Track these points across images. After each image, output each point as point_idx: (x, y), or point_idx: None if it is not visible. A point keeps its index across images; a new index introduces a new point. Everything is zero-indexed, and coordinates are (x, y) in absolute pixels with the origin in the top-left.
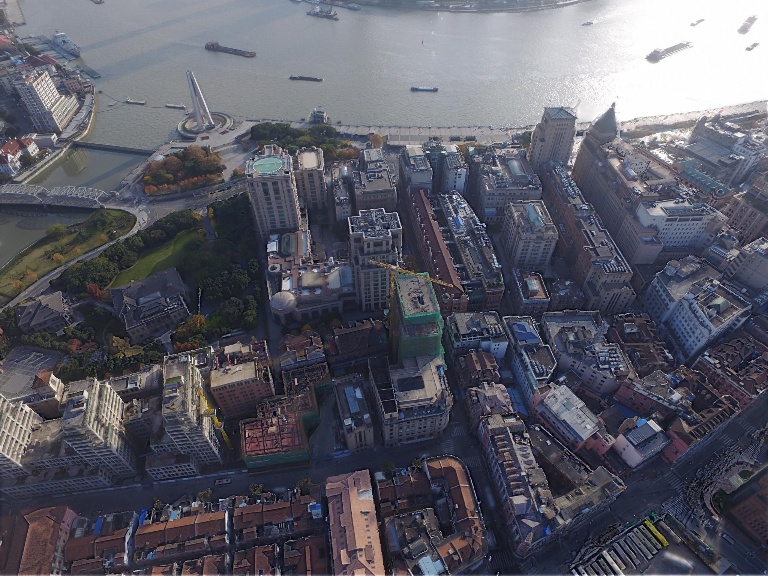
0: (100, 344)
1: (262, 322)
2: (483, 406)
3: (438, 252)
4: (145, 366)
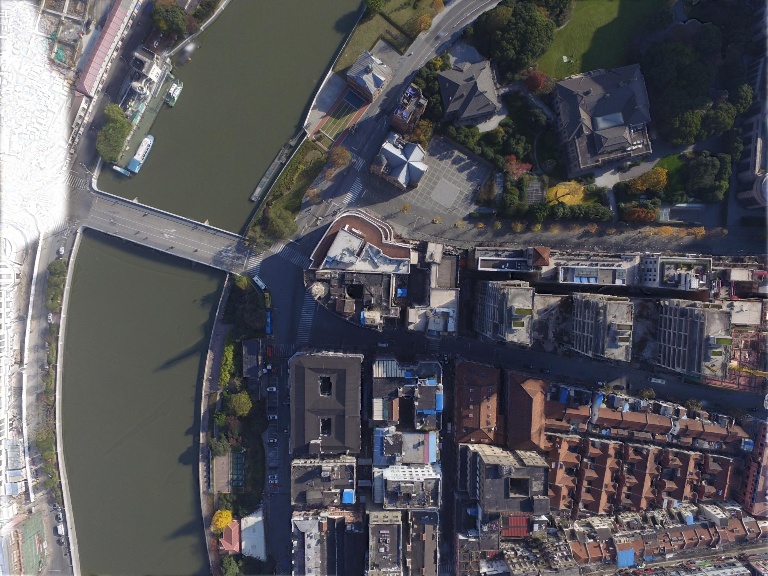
0: (533, 166)
1: None
2: None
3: None
4: (628, 254)
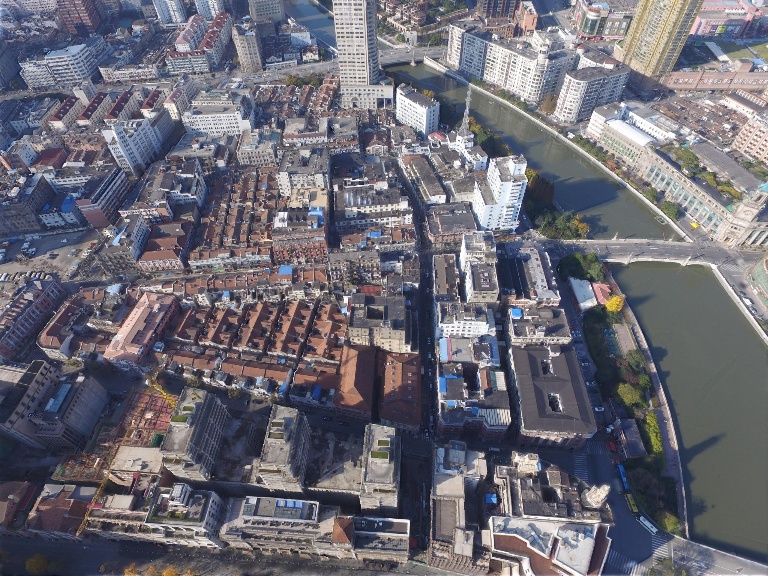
0: None
1: None
2: None
3: None
4: (234, 536)
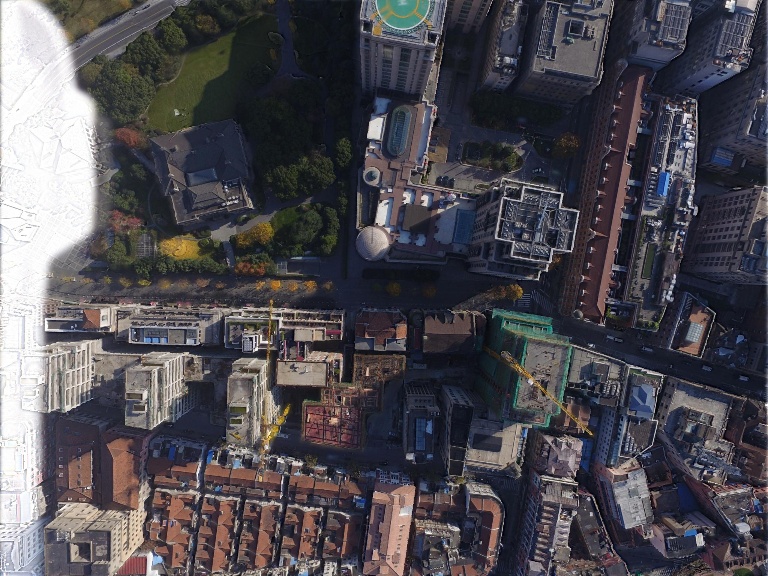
0: (146, 219)
1: (342, 246)
2: (549, 466)
3: (604, 237)
4: (203, 314)
